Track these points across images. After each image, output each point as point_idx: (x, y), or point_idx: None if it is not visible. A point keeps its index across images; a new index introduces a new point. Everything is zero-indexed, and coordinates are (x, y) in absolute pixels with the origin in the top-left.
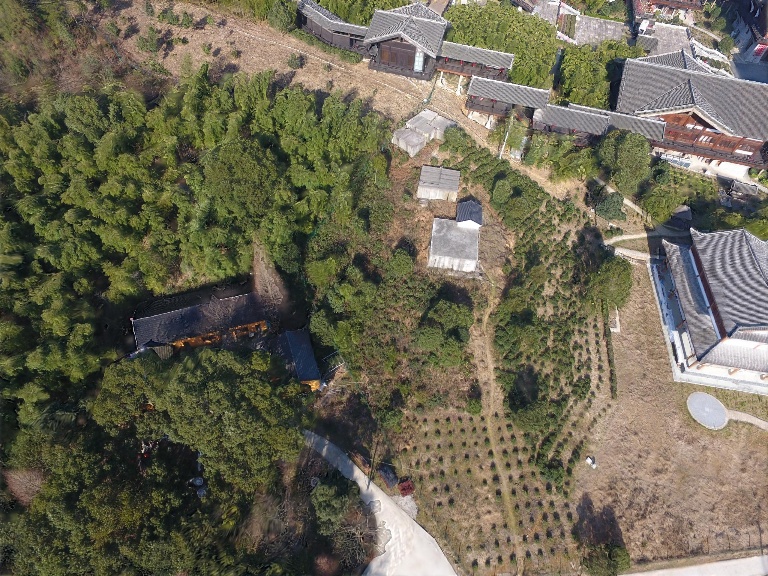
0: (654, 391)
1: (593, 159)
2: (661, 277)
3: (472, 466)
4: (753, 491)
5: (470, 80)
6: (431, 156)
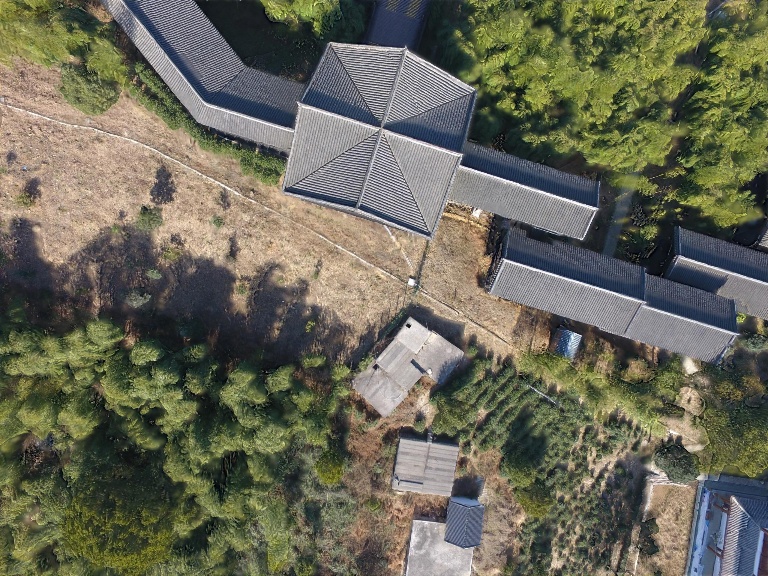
0: None
1: None
2: (709, 515)
3: None
4: None
5: (498, 264)
6: (415, 409)
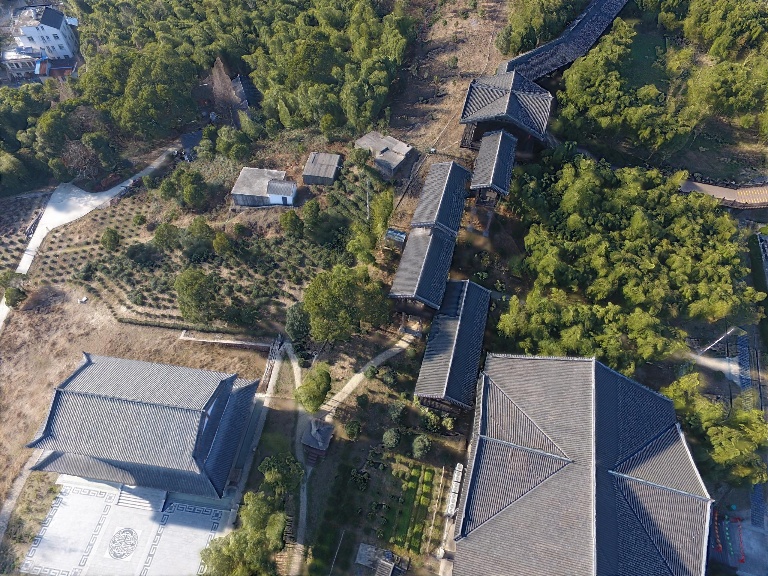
0: (112, 352)
1: None
2: None
3: None
4: (2, 417)
5: None
6: None
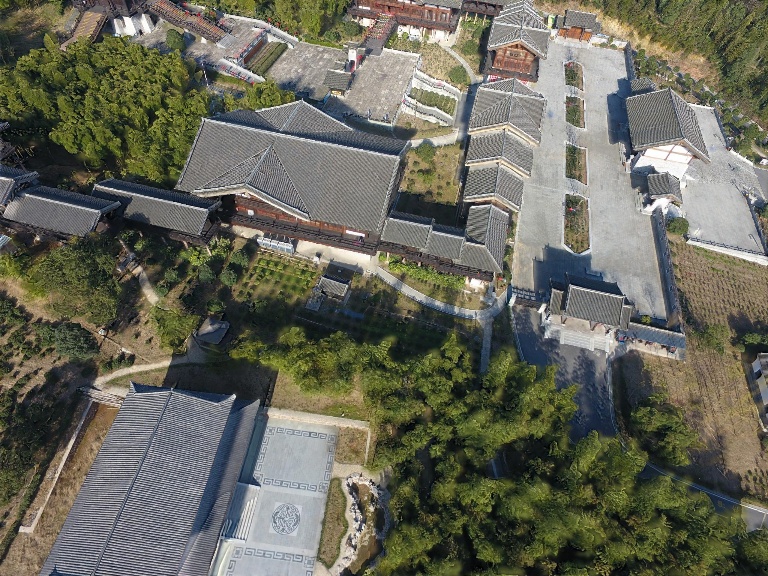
0: None
1: (151, 251)
2: None
3: None
4: None
5: None
6: None
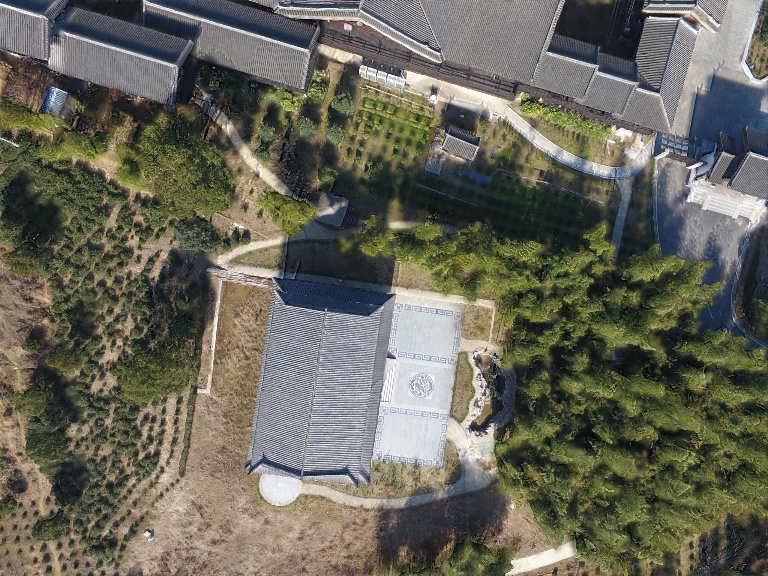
0: (227, 467)
1: (232, 92)
2: None
3: (23, 547)
4: (302, 556)
5: None
6: None
